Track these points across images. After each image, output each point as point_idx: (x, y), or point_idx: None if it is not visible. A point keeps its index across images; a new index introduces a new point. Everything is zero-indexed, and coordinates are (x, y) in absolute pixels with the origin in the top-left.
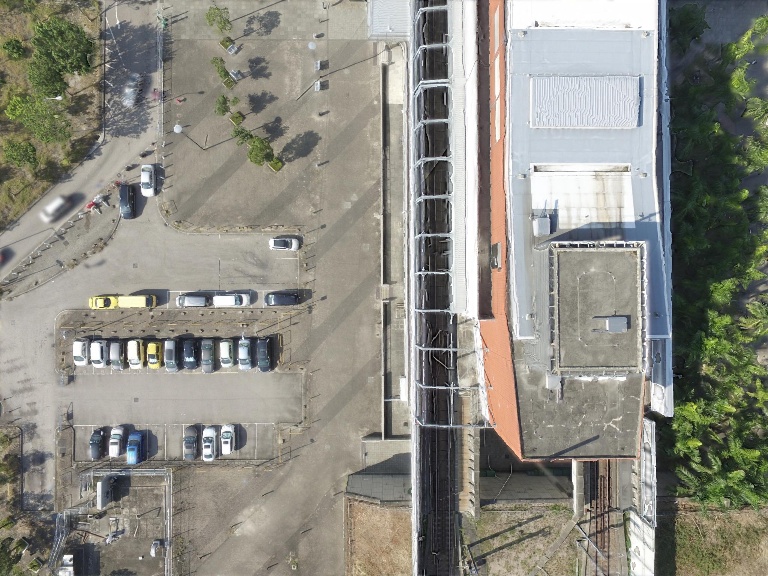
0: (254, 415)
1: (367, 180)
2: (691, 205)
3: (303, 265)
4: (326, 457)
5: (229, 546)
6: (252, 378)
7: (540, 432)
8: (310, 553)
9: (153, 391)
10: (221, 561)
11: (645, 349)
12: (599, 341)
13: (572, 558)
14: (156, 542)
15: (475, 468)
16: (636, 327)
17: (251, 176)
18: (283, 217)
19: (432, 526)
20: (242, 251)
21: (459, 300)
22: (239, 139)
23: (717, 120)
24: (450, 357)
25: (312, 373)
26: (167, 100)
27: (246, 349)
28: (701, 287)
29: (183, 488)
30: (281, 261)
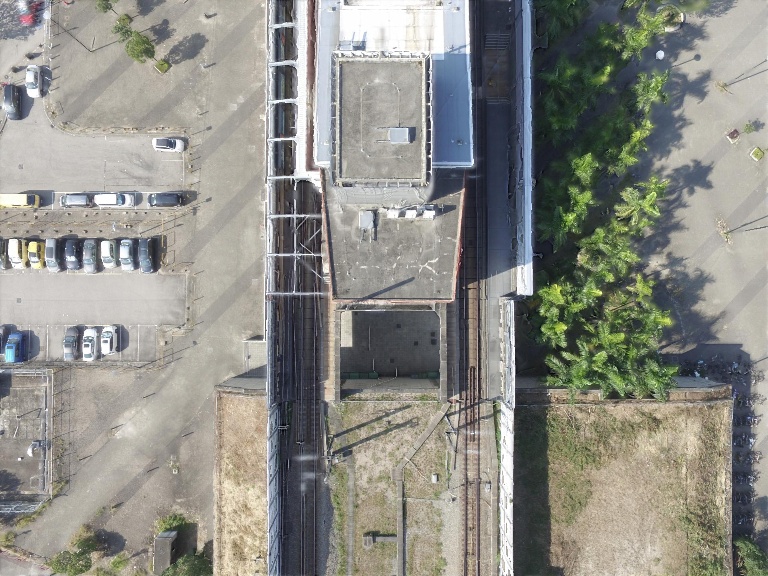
0: (137, 317)
1: (253, 82)
2: (551, 81)
3: (188, 166)
4: (209, 360)
5: (110, 449)
6: (135, 279)
7: (354, 273)
8: (191, 457)
9: (36, 292)
10: (101, 464)
11: (430, 161)
12: (382, 153)
13: (441, 450)
14: (35, 443)
15: (336, 351)
16: (420, 139)
17: (137, 78)
18: (169, 119)
19: (297, 415)
20: (128, 153)
21: (302, 165)
22: (120, 36)
23: (586, 3)
24: (317, 244)
25: (196, 275)
26: (55, 3)
27: (127, 248)
28: (565, 167)
29: (64, 389)
30: (166, 163)
